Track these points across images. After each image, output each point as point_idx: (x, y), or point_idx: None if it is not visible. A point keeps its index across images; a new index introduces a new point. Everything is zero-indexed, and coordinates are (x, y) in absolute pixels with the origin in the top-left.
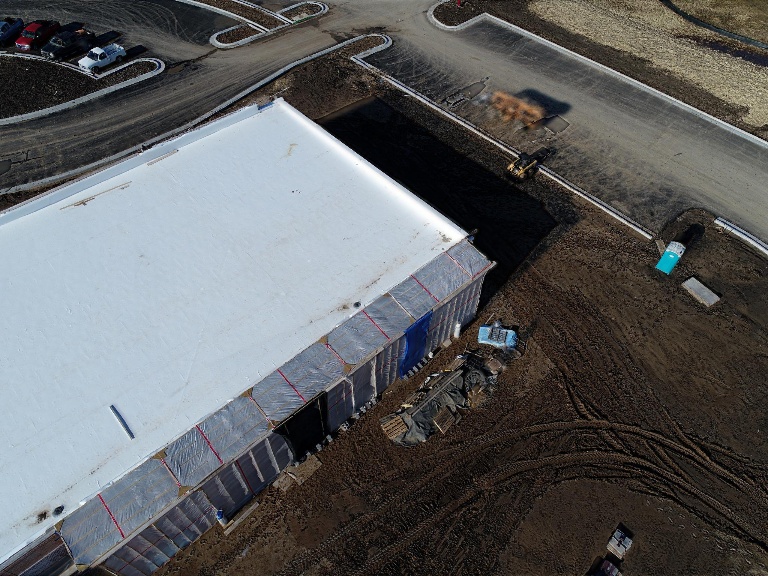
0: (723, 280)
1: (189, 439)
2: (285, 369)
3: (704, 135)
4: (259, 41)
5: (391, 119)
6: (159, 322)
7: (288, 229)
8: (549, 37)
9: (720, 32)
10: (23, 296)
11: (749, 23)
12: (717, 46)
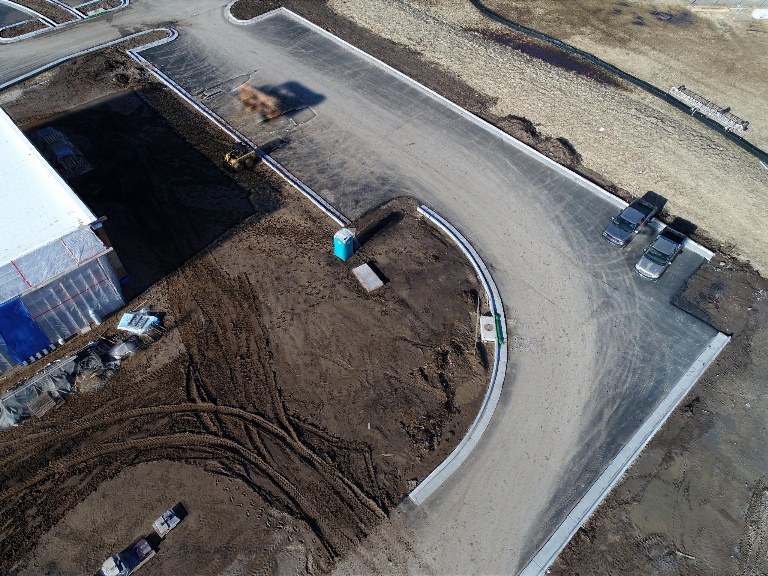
0: (397, 266)
1: None
2: None
3: (445, 125)
4: (43, 35)
5: (136, 111)
6: None
7: None
8: (334, 31)
9: (509, 25)
10: None
11: (544, 16)
12: (502, 39)
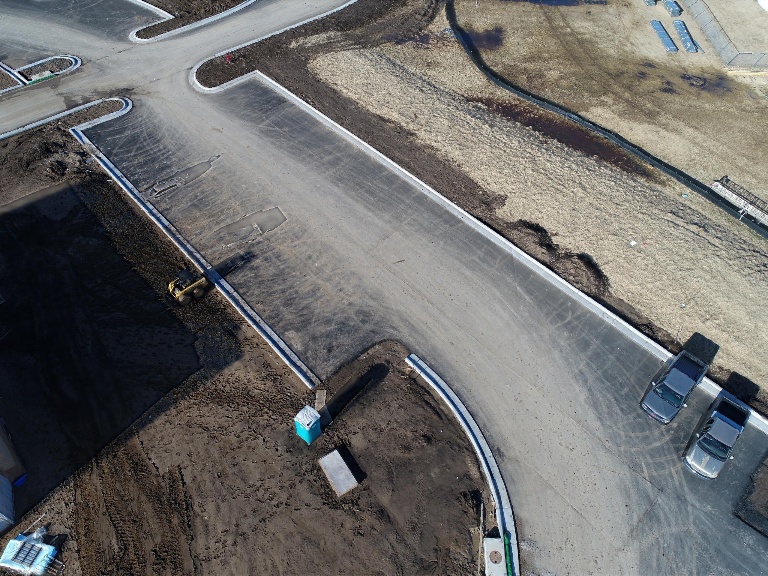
0: (377, 452)
1: None
2: None
3: (441, 234)
4: None
5: (68, 215)
6: None
7: None
8: (315, 102)
9: (518, 94)
10: None
11: (559, 82)
12: (510, 112)
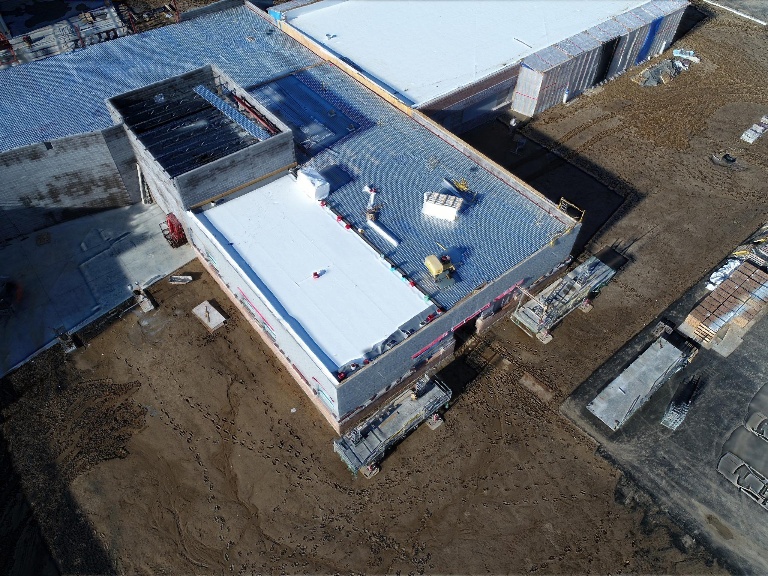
0: None
1: (565, 42)
2: (599, 26)
3: None
4: None
5: None
6: (520, 16)
7: None
8: None
9: None
10: (444, 4)
11: None
12: None
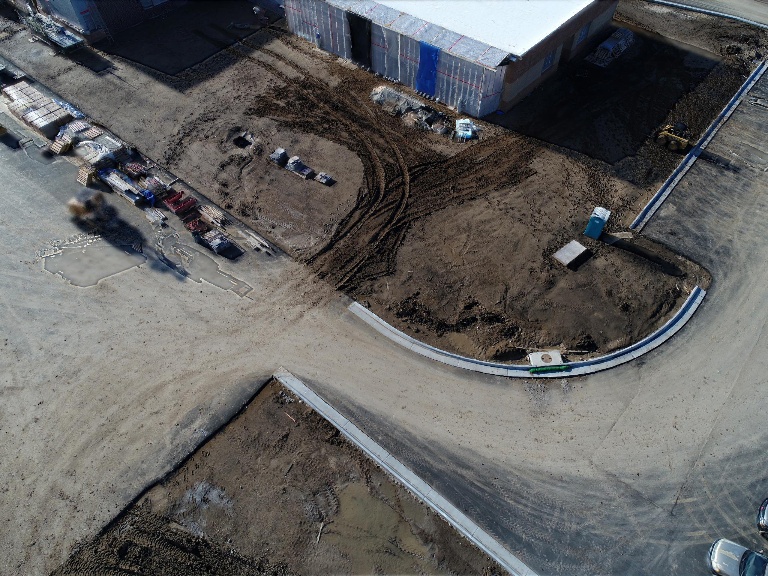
0: (597, 275)
1: None
2: (380, 5)
3: None
4: None
5: (694, 68)
6: None
7: (491, 1)
8: None
9: None
10: None
11: None
12: None
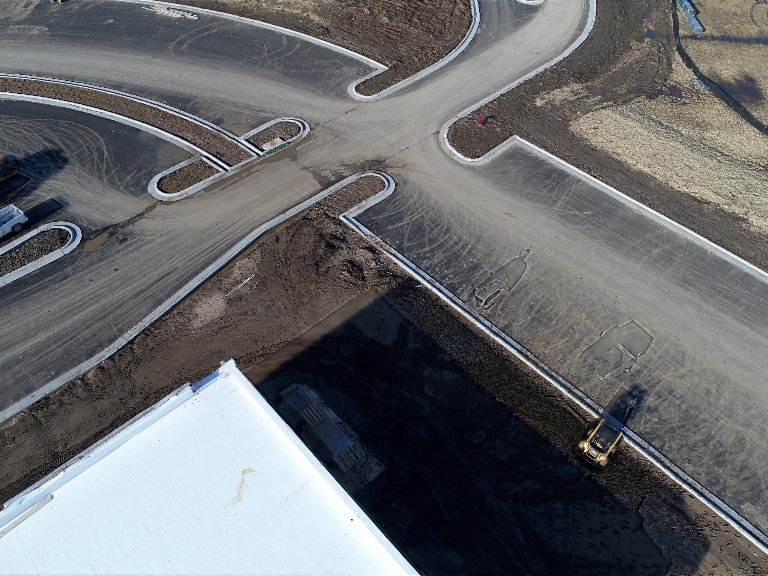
0: None
1: None
2: None
3: None
4: (215, 187)
5: (399, 337)
6: None
7: None
8: (603, 176)
9: None
10: None
11: None
12: None
